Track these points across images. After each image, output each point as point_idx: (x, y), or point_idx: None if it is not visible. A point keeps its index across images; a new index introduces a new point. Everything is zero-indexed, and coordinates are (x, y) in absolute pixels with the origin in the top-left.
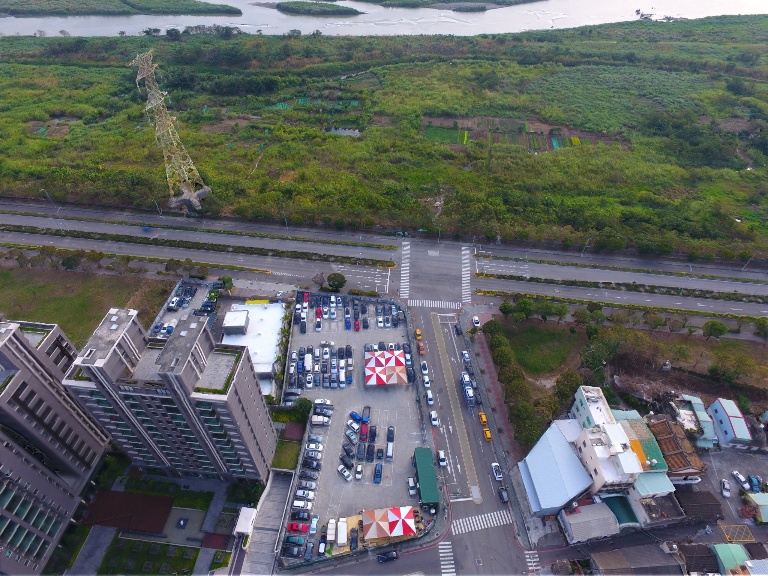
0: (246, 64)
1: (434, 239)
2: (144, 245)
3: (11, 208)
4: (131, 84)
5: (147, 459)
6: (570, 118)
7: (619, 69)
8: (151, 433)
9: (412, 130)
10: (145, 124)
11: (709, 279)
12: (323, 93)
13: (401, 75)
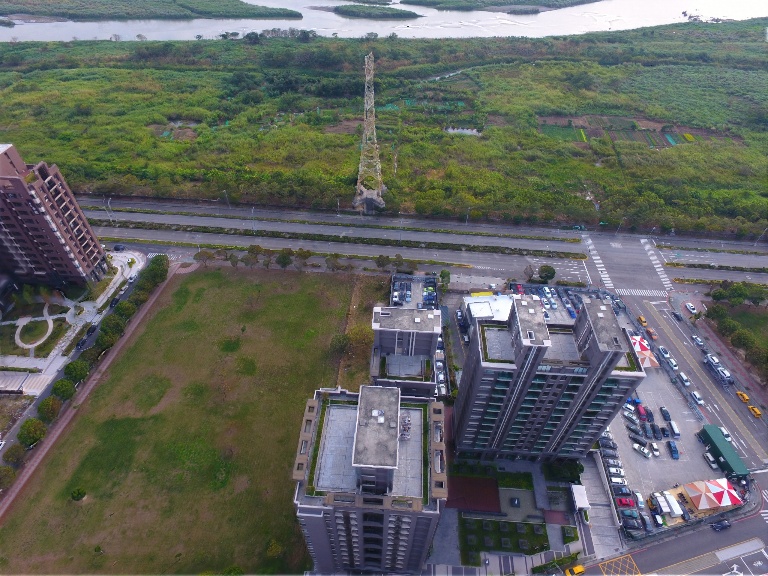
0: (339, 66)
1: (610, 232)
2: (337, 243)
3: (186, 210)
4: (236, 87)
5: (479, 442)
6: (675, 116)
7: (698, 68)
8: (517, 414)
9: (532, 129)
10: (267, 126)
11: None
12: (428, 94)
13: (494, 76)
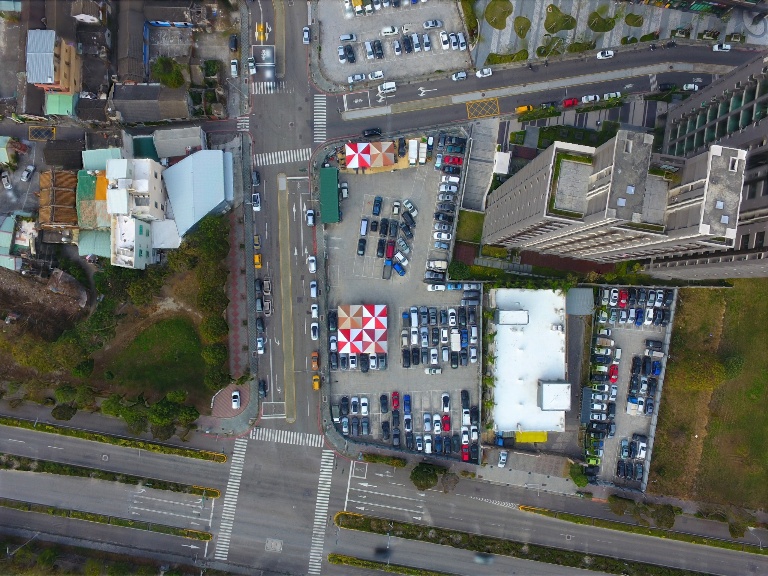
0: None
1: None
2: (720, 574)
3: None
4: None
5: None
6: None
7: None
8: None
9: None
10: None
11: None
12: None
13: None
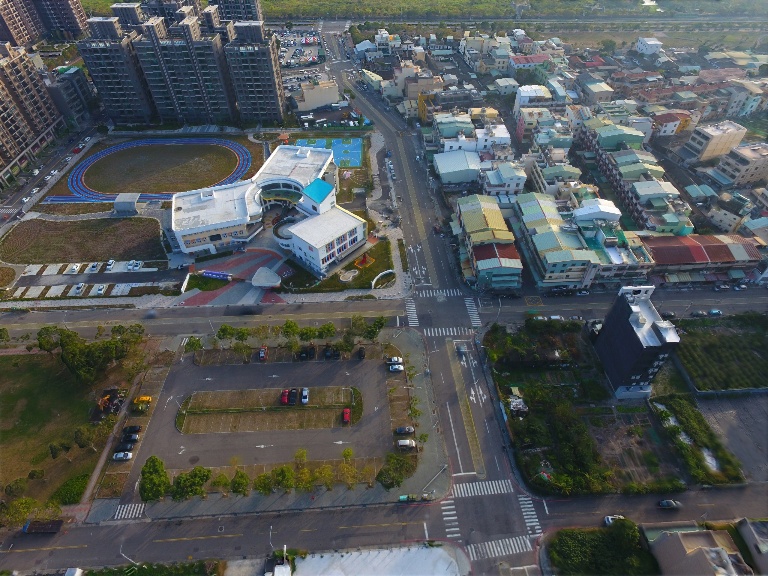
0: None
1: (335, 19)
2: None
3: None
4: None
5: None
6: None
7: None
8: None
9: None
10: None
11: (454, 22)
12: None
13: None
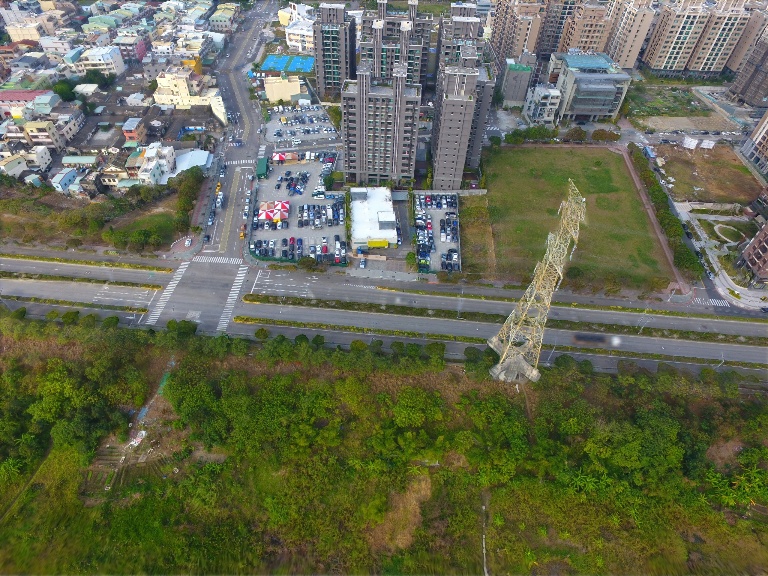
0: None
1: None
2: None
3: (763, 374)
4: None
5: None
6: None
7: None
8: None
9: None
10: None
11: None
12: None
13: None
